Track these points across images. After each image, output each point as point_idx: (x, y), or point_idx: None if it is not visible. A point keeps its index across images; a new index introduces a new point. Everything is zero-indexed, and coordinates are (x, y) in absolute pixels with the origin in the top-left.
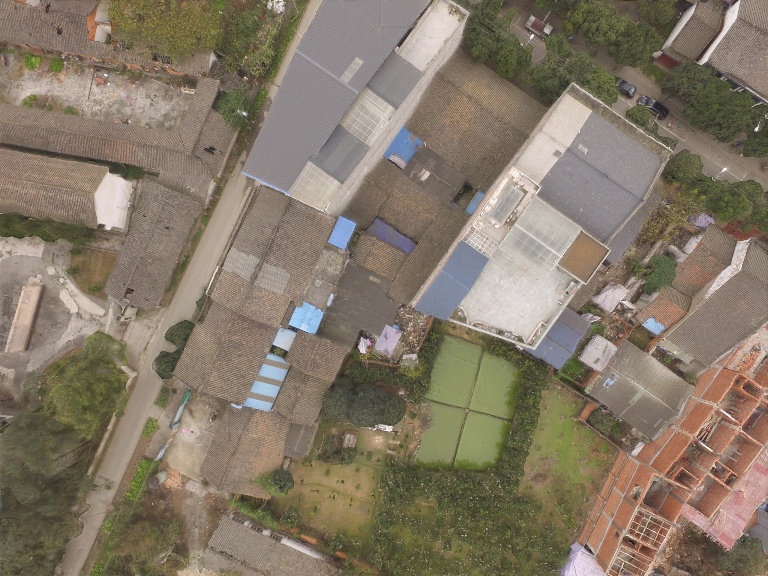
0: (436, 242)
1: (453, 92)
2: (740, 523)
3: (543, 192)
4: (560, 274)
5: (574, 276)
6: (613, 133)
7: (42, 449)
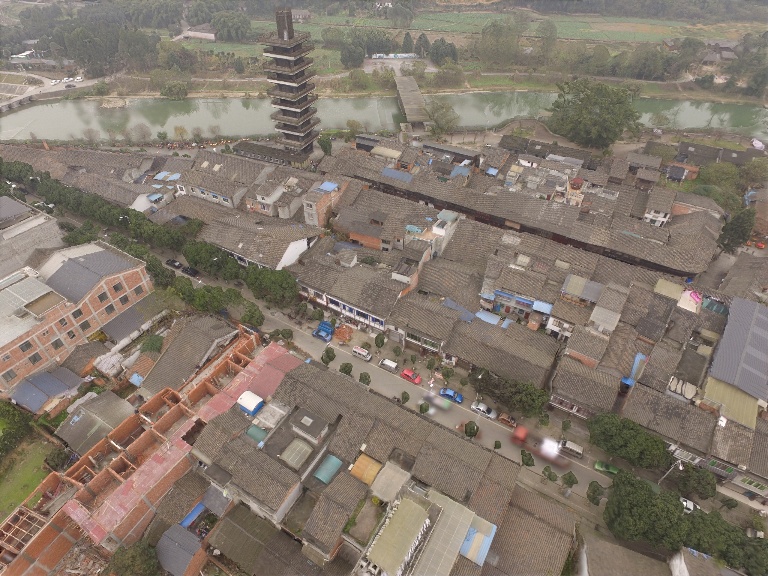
0: None
1: (42, 257)
2: (120, 513)
3: (49, 282)
4: (36, 322)
5: (32, 313)
6: None
7: None
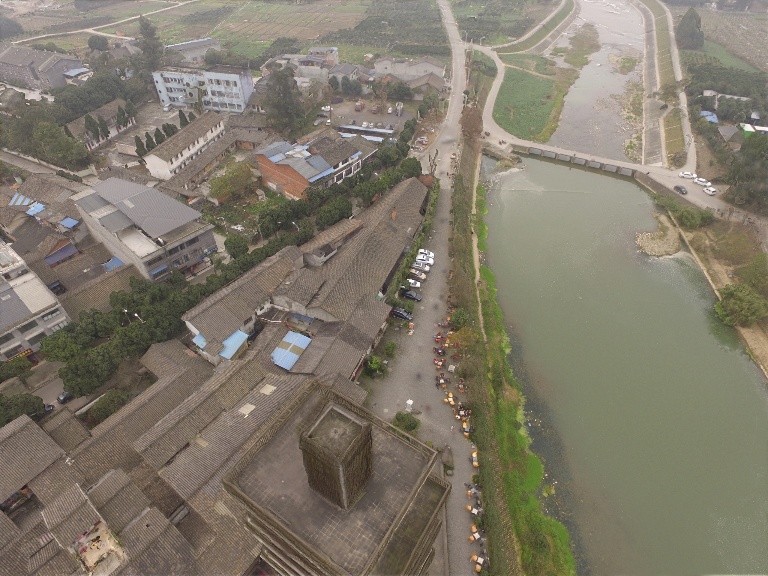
0: (33, 263)
1: None
2: None
3: None
4: None
5: None
6: (6, 321)
7: (32, 119)
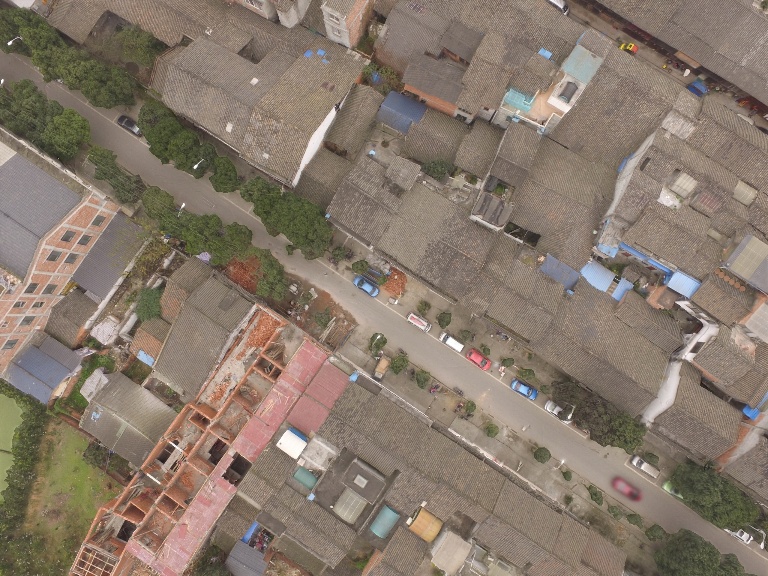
0: None
1: None
2: (184, 557)
3: None
4: None
5: None
6: (33, 174)
7: None
